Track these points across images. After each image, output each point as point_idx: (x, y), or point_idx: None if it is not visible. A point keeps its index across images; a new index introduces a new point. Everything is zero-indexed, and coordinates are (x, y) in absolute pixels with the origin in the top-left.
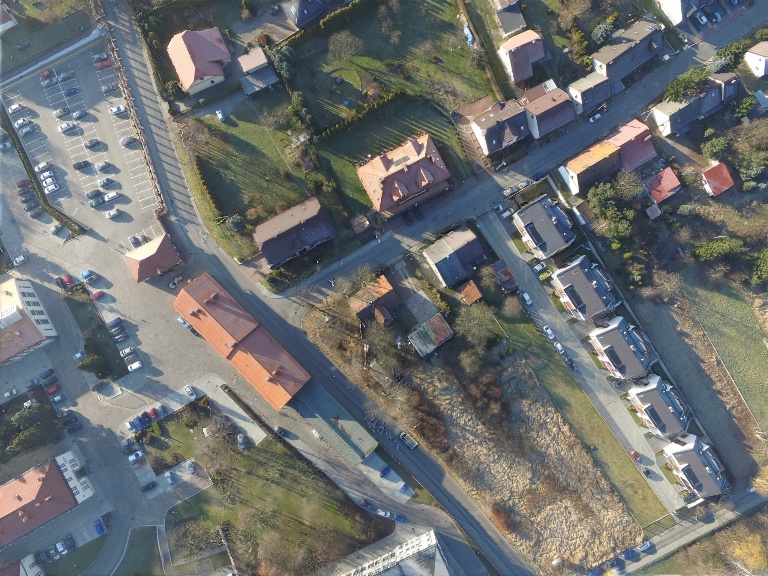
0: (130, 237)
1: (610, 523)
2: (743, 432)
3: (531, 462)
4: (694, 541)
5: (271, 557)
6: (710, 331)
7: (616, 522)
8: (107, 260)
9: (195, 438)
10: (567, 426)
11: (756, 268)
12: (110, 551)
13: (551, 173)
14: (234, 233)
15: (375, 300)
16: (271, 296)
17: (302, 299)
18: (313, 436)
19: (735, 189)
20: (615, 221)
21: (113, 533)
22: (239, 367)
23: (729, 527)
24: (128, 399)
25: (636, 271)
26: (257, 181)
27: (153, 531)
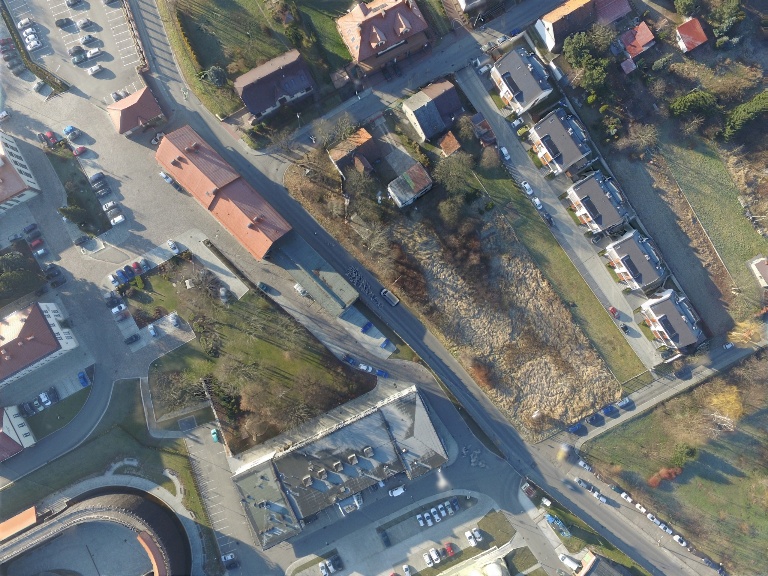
0: (112, 93)
1: (589, 379)
2: (719, 289)
3: (511, 318)
4: (672, 397)
5: (254, 410)
6: (686, 188)
7: (595, 378)
8: (90, 117)
9: (178, 292)
10: (546, 282)
11: (729, 120)
12: (94, 403)
13: (528, 30)
14: (215, 88)
15: (355, 148)
16: (253, 153)
17: (283, 156)
18: (295, 292)
19: (709, 47)
20: (590, 68)
21: (97, 385)
22: (221, 217)
23: (706, 382)
24: (111, 253)
25: (612, 125)
26: (238, 37)
27: (136, 383)
